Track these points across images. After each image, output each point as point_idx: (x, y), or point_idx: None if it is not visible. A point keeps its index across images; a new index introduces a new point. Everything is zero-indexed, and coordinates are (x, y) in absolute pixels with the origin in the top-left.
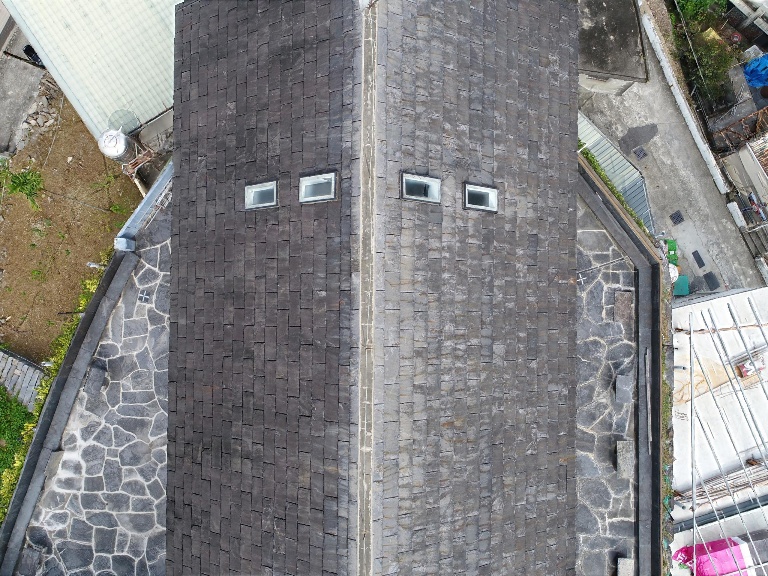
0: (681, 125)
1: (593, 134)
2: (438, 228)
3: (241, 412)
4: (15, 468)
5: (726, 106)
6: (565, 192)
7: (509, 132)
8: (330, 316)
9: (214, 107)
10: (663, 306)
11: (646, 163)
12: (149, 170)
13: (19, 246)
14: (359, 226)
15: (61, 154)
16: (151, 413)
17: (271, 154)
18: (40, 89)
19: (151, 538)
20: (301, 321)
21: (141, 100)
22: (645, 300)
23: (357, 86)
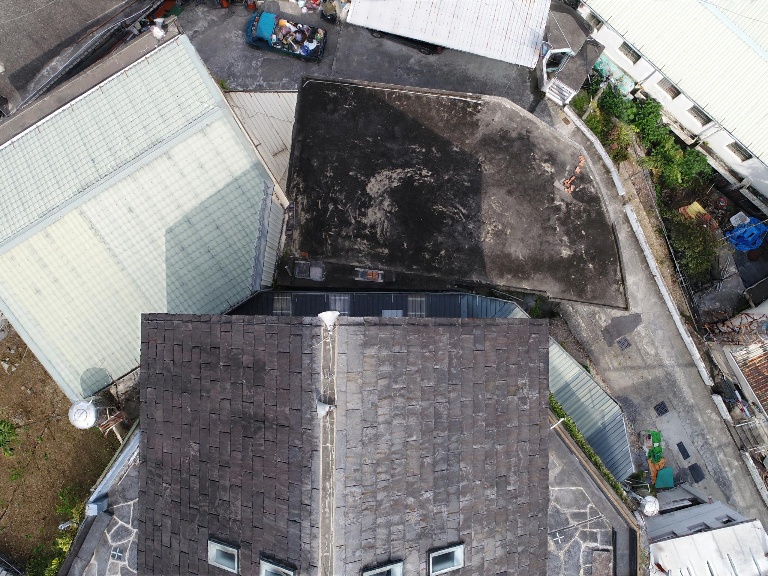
0: (665, 314)
1: (572, 368)
2: None
3: None
4: None
5: (711, 285)
6: (535, 514)
7: (476, 478)
8: None
9: (178, 439)
10: (641, 571)
11: (630, 353)
12: (124, 404)
13: None
14: None
15: None
16: None
17: (233, 517)
18: None
19: None
20: None
21: (113, 358)
22: (623, 563)
23: (315, 491)
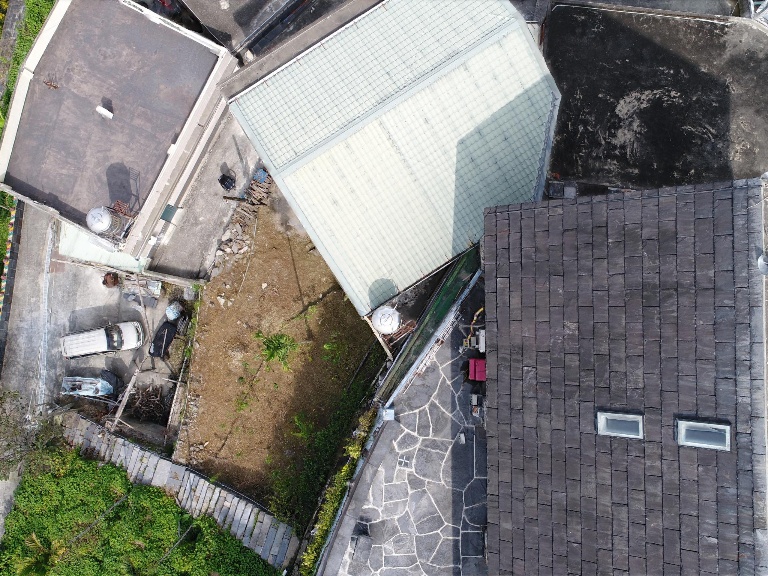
0: None
1: None
2: None
3: None
4: None
5: None
6: None
7: None
8: (725, 565)
9: (546, 321)
10: None
11: None
12: None
13: (215, 372)
14: (765, 485)
15: (255, 280)
16: None
17: (632, 386)
18: (233, 216)
19: None
20: (683, 562)
21: (400, 269)
22: None
23: (757, 345)
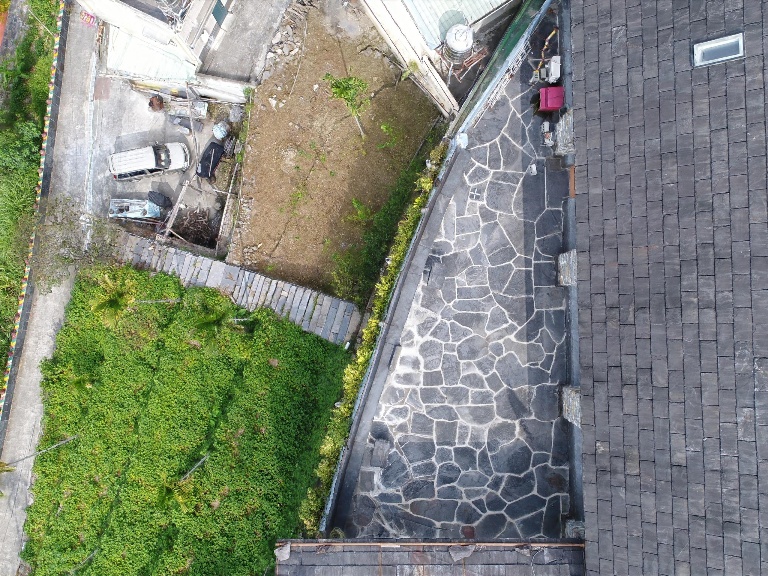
0: None
1: None
2: None
3: (695, 265)
4: (358, 364)
5: None
6: None
7: None
8: None
9: None
10: None
11: None
12: None
13: (268, 174)
14: None
15: (306, 82)
16: (487, 308)
17: (730, 9)
18: (284, 19)
19: (491, 429)
20: None
21: (470, 0)
22: None
23: None
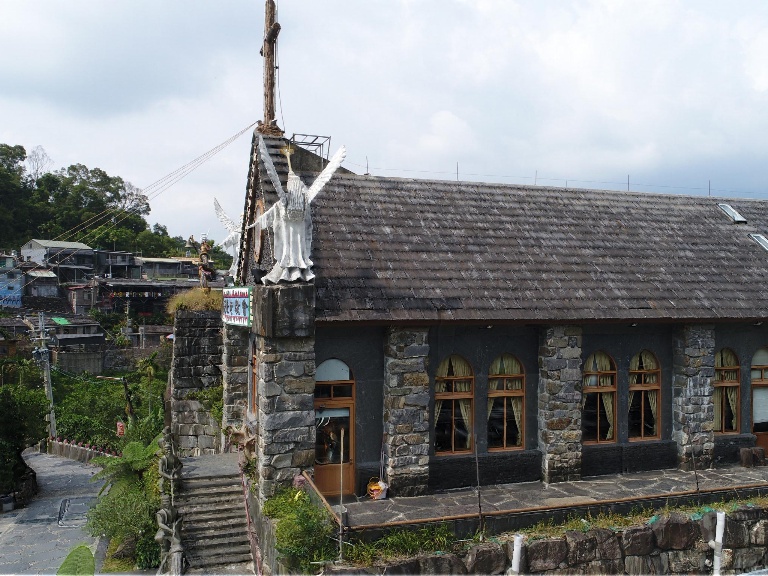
0: None
1: None
2: (722, 222)
3: None
4: None
5: None
6: None
7: None
8: None
9: None
10: None
11: None
12: None
13: None
14: None
15: None
16: None
17: None
18: None
19: None
20: None
21: None
22: None
23: None
